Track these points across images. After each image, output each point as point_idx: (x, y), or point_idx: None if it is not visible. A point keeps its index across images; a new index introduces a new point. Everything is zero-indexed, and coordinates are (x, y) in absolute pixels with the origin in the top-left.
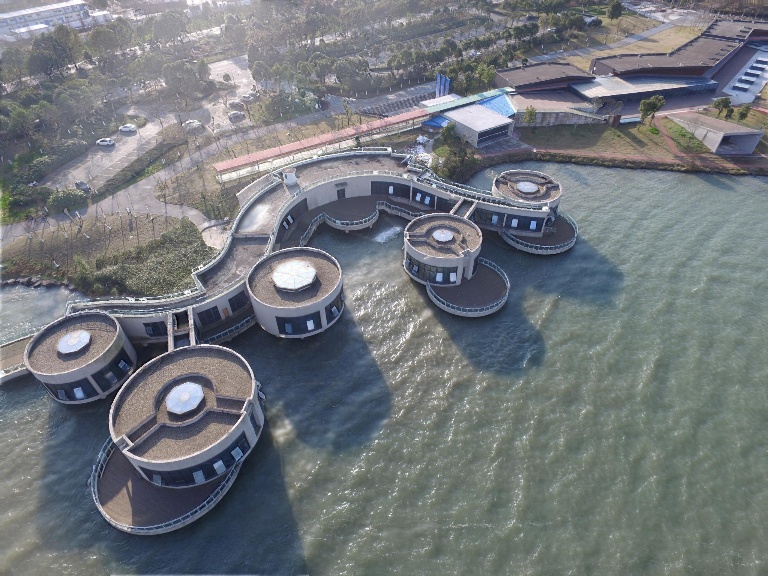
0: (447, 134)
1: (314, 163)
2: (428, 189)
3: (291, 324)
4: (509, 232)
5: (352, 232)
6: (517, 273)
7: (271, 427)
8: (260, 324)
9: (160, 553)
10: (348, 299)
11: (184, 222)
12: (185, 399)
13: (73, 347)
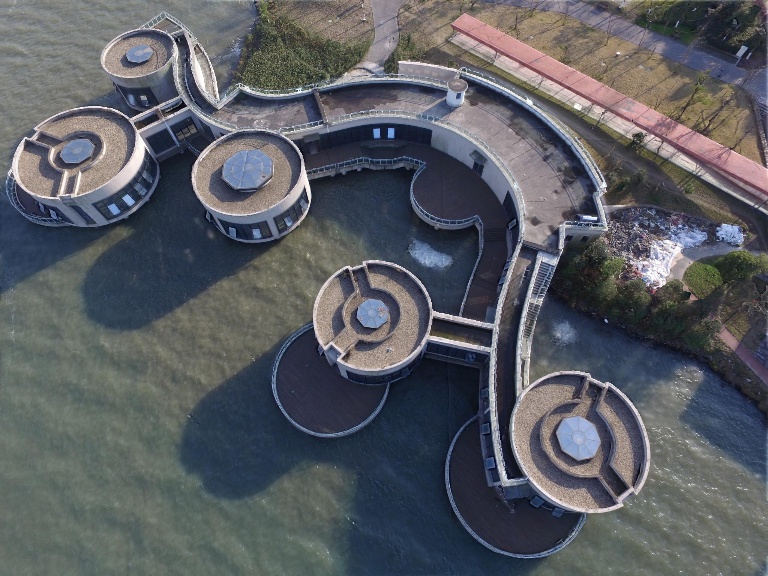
0: (727, 263)
1: (521, 108)
2: None
3: None
4: None
5: None
6: (389, 449)
7: (110, 233)
8: None
9: (1, 205)
10: (288, 244)
11: (359, 46)
12: (74, 152)
13: (132, 56)
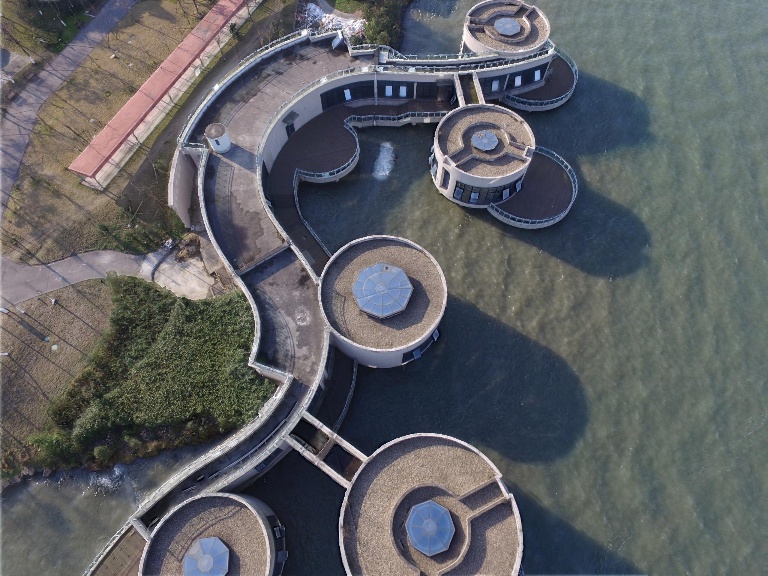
0: None
1: (220, 98)
2: (403, 77)
3: (419, 349)
4: (511, 94)
5: (343, 177)
6: (552, 143)
7: None
8: (366, 365)
9: None
10: None
11: (118, 283)
12: (434, 529)
13: (216, 571)
